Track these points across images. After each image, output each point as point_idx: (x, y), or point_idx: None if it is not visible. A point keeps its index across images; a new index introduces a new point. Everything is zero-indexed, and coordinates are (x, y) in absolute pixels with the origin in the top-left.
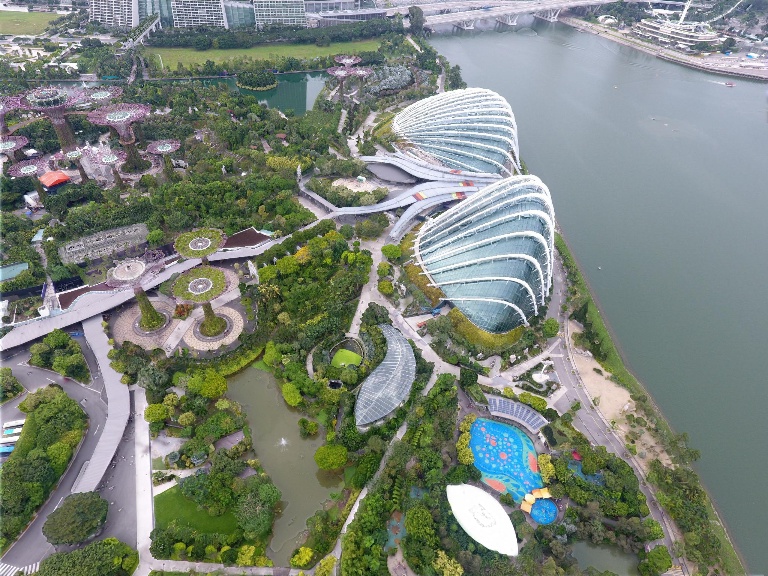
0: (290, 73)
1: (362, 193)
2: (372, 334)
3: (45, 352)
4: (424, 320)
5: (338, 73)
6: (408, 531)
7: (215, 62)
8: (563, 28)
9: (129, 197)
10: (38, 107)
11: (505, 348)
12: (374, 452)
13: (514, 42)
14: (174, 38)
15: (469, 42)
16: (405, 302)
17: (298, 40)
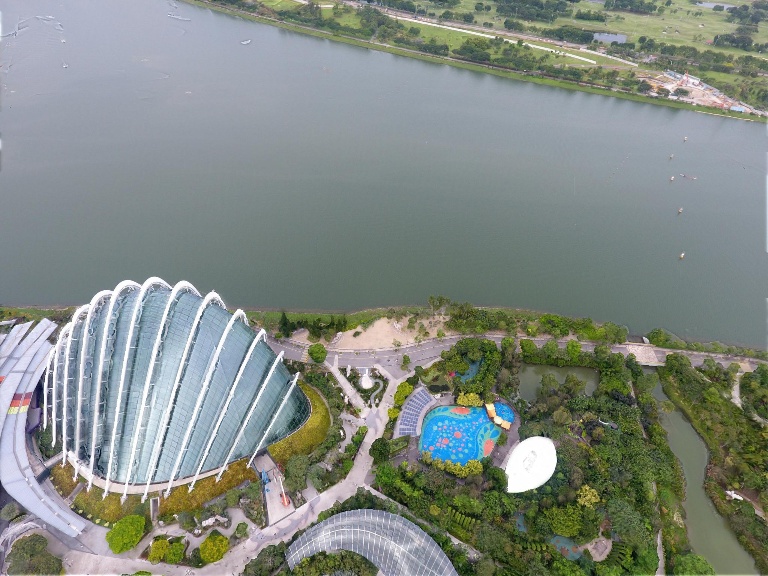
0: None
1: None
2: (314, 574)
3: None
4: (280, 495)
5: None
6: (577, 532)
7: None
8: None
9: None
10: None
11: (336, 404)
12: (496, 573)
13: None
14: None
15: None
16: (239, 521)
17: None
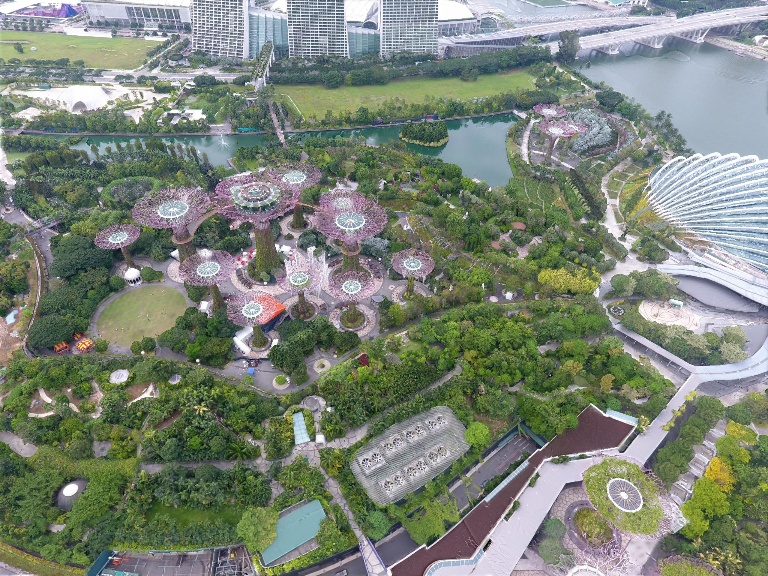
0: (453, 119)
1: (714, 339)
2: None
3: None
4: None
5: (554, 132)
6: None
7: (358, 105)
8: (711, 50)
9: (405, 356)
10: (248, 213)
11: None
12: None
13: (676, 71)
14: (297, 73)
15: (613, 69)
16: None
17: (439, 73)
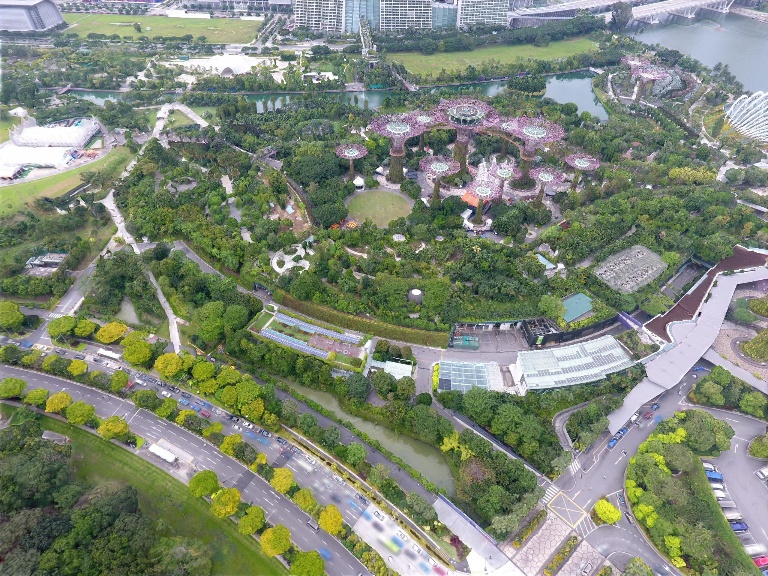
0: None
1: None
2: None
3: (727, 391)
4: None
5: (647, 76)
6: None
7: (458, 67)
8: (736, 19)
9: (601, 217)
10: (464, 125)
11: None
12: None
13: (712, 35)
14: (394, 42)
15: None
16: None
17: (515, 40)
